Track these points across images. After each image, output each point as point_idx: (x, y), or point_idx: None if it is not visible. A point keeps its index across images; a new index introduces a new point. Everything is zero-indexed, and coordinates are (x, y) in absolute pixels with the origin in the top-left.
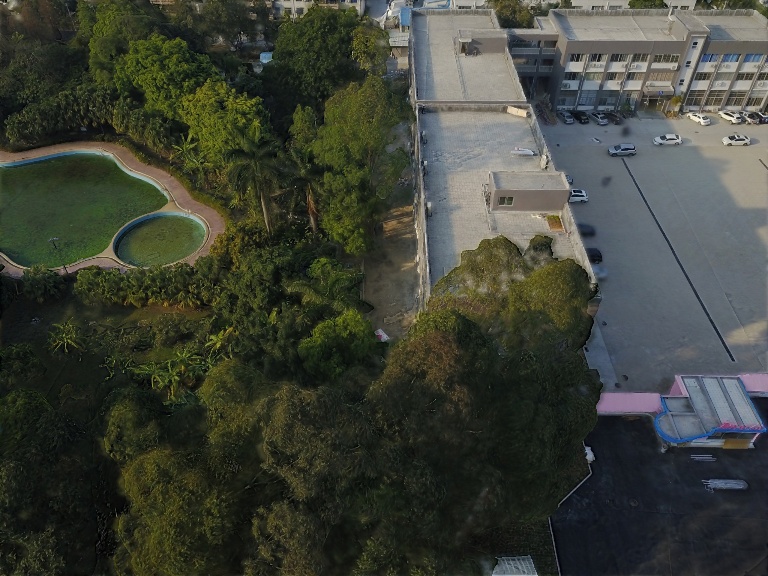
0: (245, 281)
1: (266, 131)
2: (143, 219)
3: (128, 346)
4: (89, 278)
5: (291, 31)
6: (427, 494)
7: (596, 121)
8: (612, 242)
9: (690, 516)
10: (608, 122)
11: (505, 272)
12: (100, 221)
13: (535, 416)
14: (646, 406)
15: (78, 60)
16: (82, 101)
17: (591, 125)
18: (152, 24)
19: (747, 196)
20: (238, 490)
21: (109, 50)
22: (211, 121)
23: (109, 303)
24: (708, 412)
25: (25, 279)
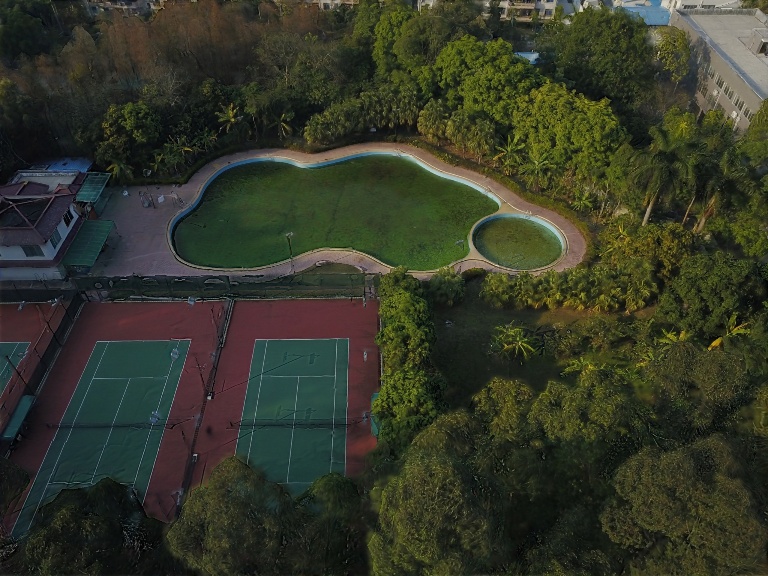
0: (710, 285)
1: (627, 132)
2: (485, 221)
3: (572, 350)
4: (503, 281)
5: (586, 31)
6: None
7: None
8: None
9: None
10: None
11: None
12: (440, 223)
13: None
14: None
15: (361, 61)
16: (385, 102)
17: None
18: (453, 24)
19: None
20: None
21: (412, 51)
22: (566, 122)
23: (521, 306)
24: None
25: (441, 282)
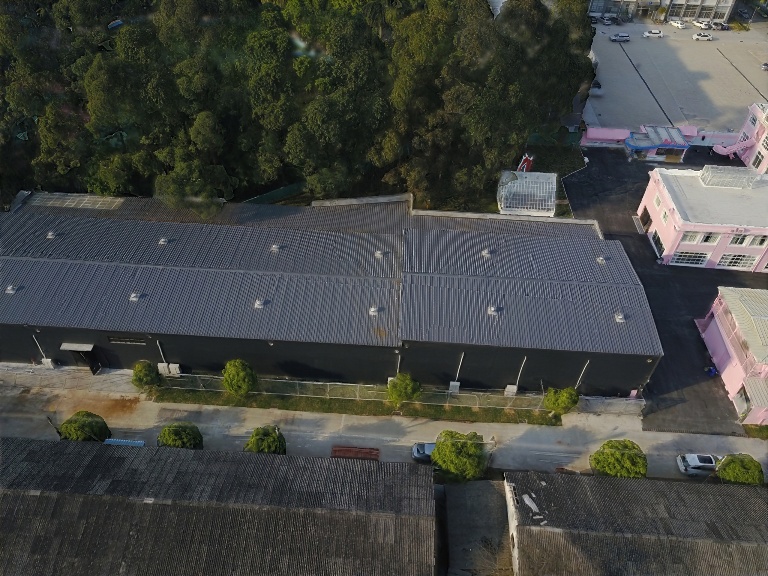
0: None
1: None
2: None
3: None
4: None
5: None
6: (518, 52)
7: (602, 22)
8: (608, 81)
9: (641, 183)
10: (611, 23)
11: (550, 0)
12: None
13: (564, 41)
14: (621, 136)
15: None
16: None
17: (599, 25)
18: None
19: (704, 65)
20: (448, 26)
21: None
22: None
23: None
24: (657, 139)
25: None
